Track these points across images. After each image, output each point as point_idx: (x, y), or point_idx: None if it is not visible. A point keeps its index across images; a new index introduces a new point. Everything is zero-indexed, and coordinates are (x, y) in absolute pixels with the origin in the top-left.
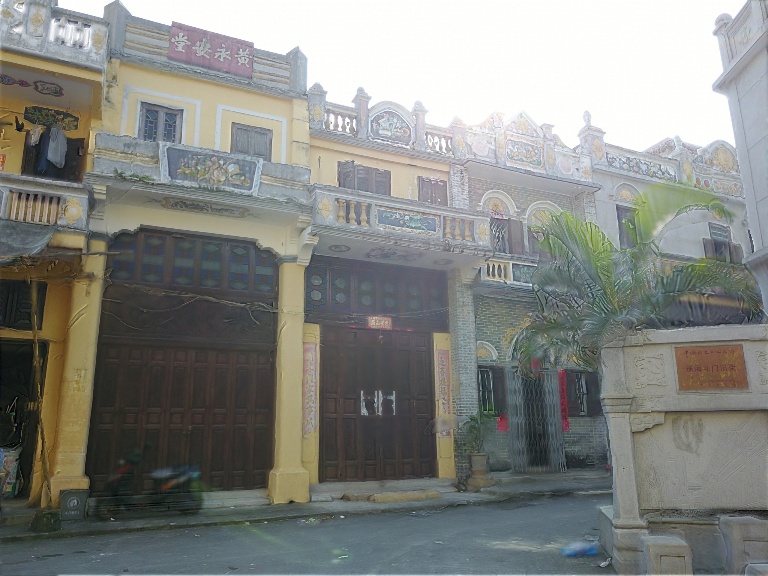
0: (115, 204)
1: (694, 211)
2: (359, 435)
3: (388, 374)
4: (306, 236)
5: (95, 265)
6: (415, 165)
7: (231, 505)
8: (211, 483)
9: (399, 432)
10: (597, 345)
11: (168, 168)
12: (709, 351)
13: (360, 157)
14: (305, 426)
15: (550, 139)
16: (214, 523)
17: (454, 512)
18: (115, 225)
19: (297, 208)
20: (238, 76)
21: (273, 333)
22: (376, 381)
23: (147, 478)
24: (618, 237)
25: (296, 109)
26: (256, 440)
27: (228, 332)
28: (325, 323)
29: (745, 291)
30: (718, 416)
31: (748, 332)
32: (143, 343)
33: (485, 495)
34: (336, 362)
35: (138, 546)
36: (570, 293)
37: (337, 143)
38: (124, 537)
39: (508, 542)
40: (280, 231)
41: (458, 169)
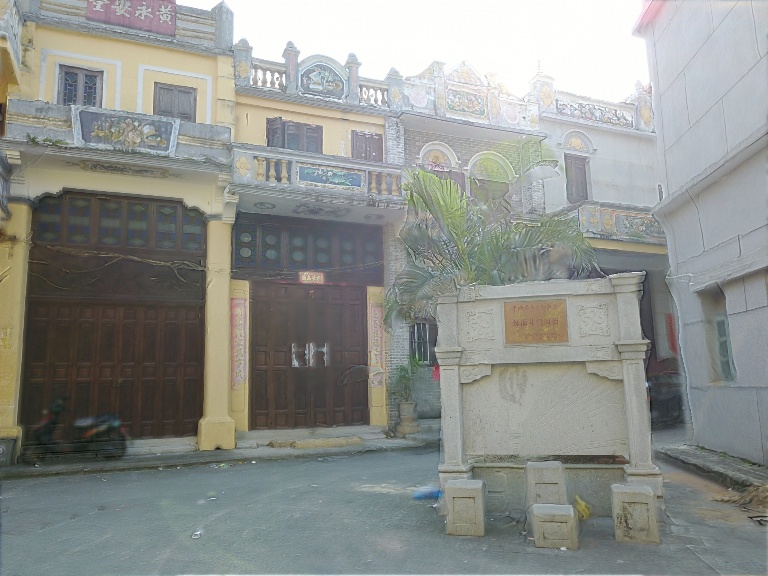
0: (33, 168)
1: (539, 167)
2: (289, 386)
3: (319, 327)
4: (226, 195)
5: (16, 228)
6: (348, 119)
7: (158, 452)
8: (141, 432)
9: (330, 382)
10: (415, 302)
11: (81, 131)
12: (535, 306)
13: (290, 113)
14: (234, 378)
15: (494, 87)
16: (127, 469)
17: (361, 457)
18: (37, 189)
19: (216, 167)
20: (160, 34)
21: (201, 290)
22: (307, 334)
23: (78, 428)
24: (565, 186)
25: (221, 66)
26: (185, 392)
27: (156, 290)
28: (254, 279)
29: (581, 246)
30: (540, 367)
31: (572, 287)
32: (70, 302)
33: (407, 441)
34: (266, 317)
35: (39, 490)
36: (431, 250)
37: (265, 99)
38: (35, 482)
39: (378, 485)
40: (206, 190)
41: (393, 122)
